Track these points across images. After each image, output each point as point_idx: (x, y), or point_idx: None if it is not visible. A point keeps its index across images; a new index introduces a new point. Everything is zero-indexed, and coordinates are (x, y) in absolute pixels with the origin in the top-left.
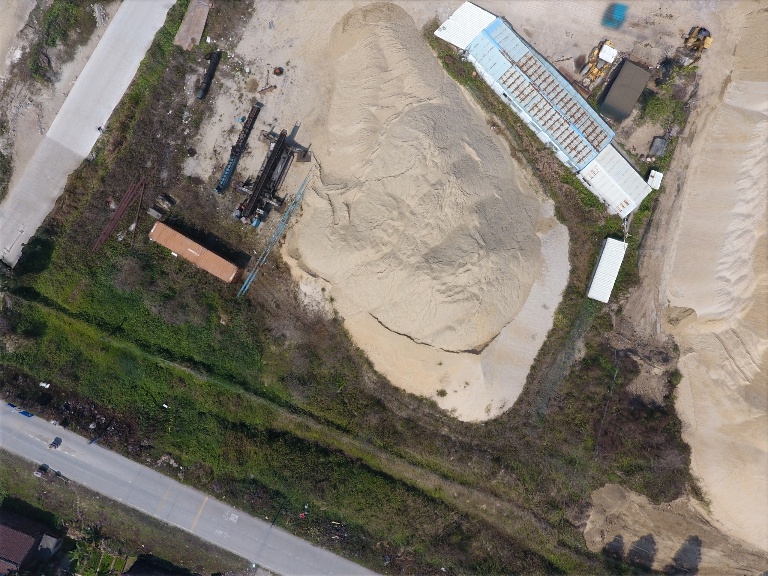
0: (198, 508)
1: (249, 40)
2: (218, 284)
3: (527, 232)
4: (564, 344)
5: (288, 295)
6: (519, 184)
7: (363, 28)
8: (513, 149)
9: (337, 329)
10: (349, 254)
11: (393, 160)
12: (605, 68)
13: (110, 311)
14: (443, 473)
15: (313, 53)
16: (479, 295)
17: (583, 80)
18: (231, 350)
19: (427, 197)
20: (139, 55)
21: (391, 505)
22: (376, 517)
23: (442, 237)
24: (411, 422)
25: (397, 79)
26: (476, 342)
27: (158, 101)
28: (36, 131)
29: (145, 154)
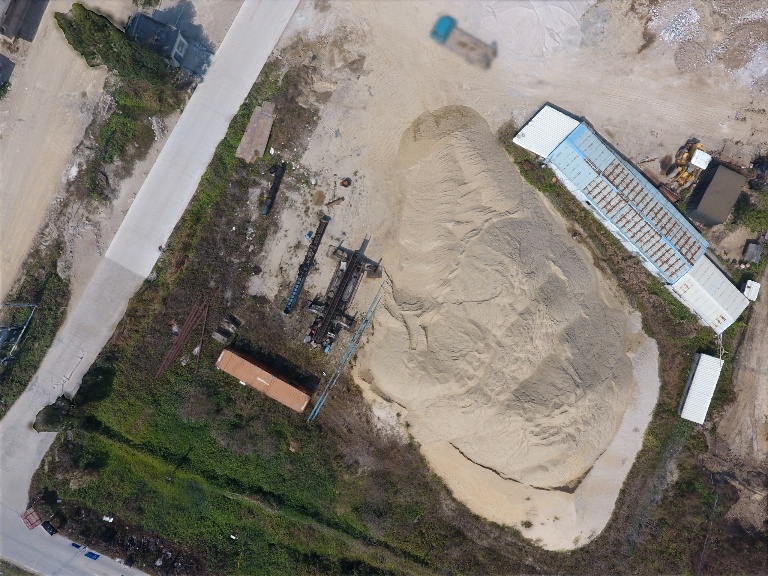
0: None
1: (315, 150)
2: (288, 412)
3: (618, 354)
4: (654, 465)
5: (360, 419)
6: (604, 297)
7: (438, 139)
8: (596, 258)
9: (412, 454)
10: (430, 385)
11: (475, 284)
12: (694, 170)
13: (175, 441)
14: None
15: (382, 162)
16: (575, 436)
17: (670, 182)
18: (302, 479)
19: (515, 328)
20: (200, 169)
21: None
22: None
23: (532, 370)
24: (493, 552)
25: (475, 192)
26: (568, 478)
27: (221, 218)
28: (94, 252)
29: (208, 274)
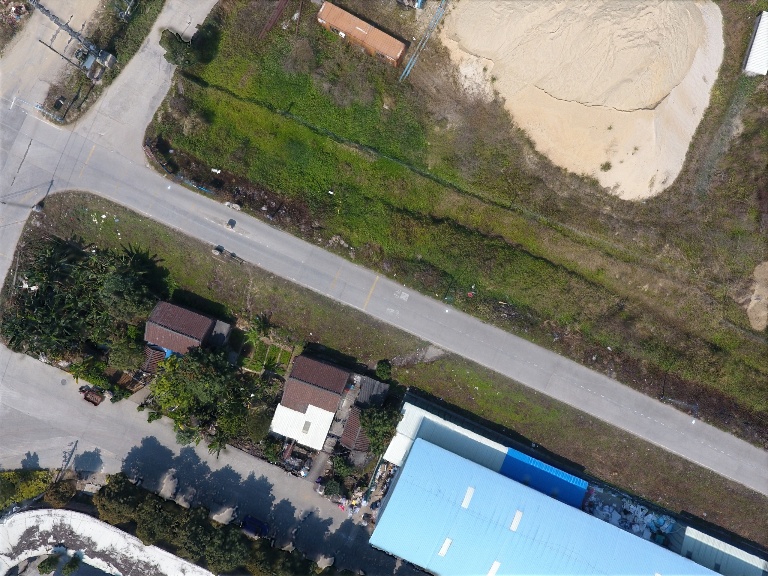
0: (369, 287)
1: None
2: (383, 66)
3: None
4: (720, 122)
5: (448, 80)
6: None
7: None
8: None
9: (497, 112)
10: (519, 19)
11: None
12: None
13: (278, 97)
14: (606, 251)
15: None
16: (658, 41)
17: None
18: (396, 132)
19: None
20: None
21: (555, 286)
22: (542, 296)
23: None
24: (574, 200)
25: None
26: (648, 101)
27: None
28: None
29: None
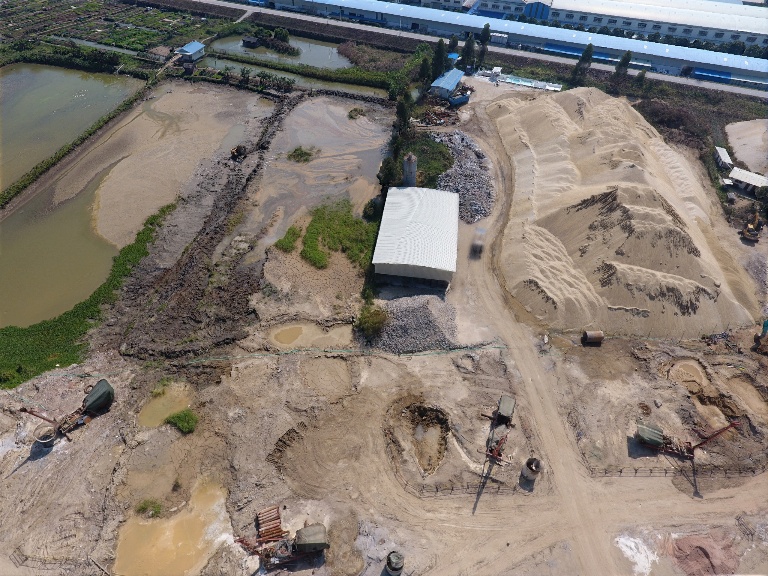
0: None
1: None
2: None
3: None
4: None
5: None
6: None
7: None
8: None
9: None
10: None
11: None
12: None
13: None
14: None
15: None
16: None
17: None
18: None
19: None
20: None
21: None
22: None
23: None
24: None
25: None
26: None
27: None
28: None
29: None
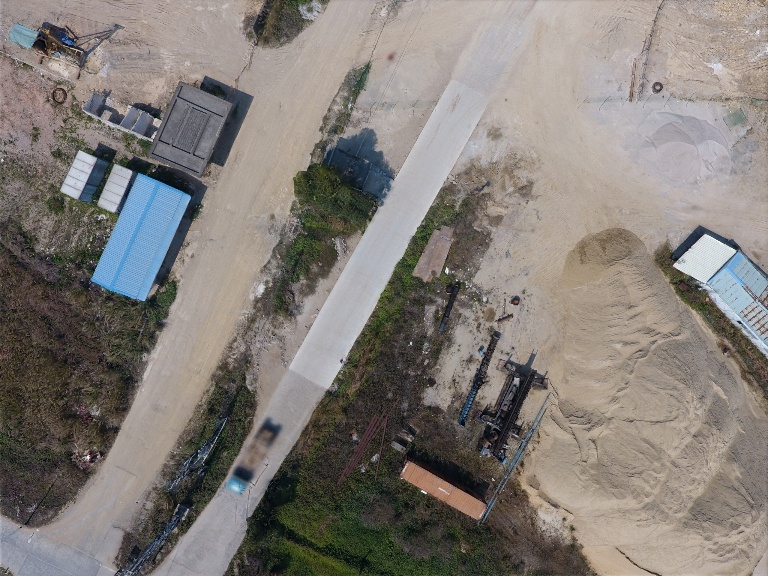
0: None
1: (486, 270)
2: (463, 517)
3: None
4: None
5: (526, 521)
6: (752, 408)
7: (609, 266)
8: (743, 371)
9: (574, 554)
10: (605, 499)
11: (647, 405)
12: None
13: (355, 544)
14: None
15: (548, 281)
16: (748, 552)
17: None
18: None
19: (690, 450)
20: (379, 287)
21: None
22: None
23: (704, 488)
24: None
25: (641, 315)
26: None
27: (399, 334)
28: (279, 364)
29: (387, 386)
